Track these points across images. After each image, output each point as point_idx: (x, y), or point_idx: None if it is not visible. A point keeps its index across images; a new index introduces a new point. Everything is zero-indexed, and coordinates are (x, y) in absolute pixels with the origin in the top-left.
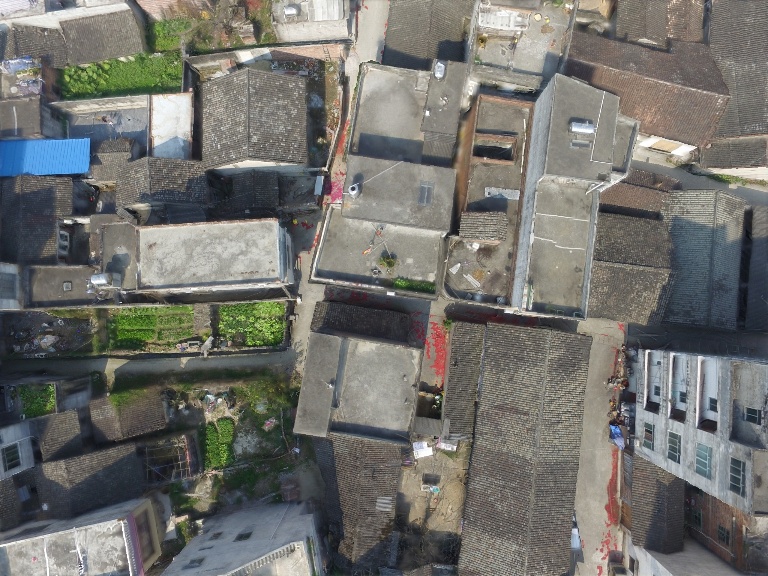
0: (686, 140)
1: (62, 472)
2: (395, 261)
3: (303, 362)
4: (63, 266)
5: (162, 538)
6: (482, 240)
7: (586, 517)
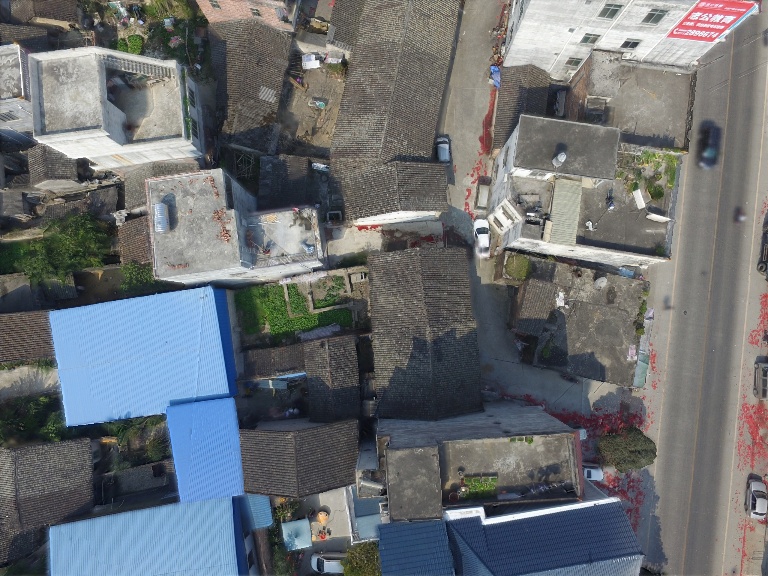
0: None
1: None
2: None
3: None
4: None
5: None
6: None
7: (461, 146)
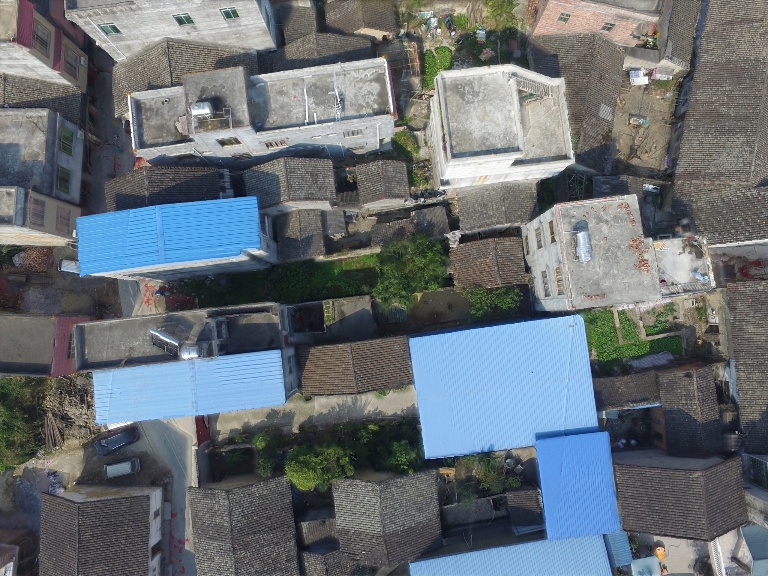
0: None
1: (310, 44)
2: None
3: (518, 5)
4: None
5: (380, 146)
6: None
7: None
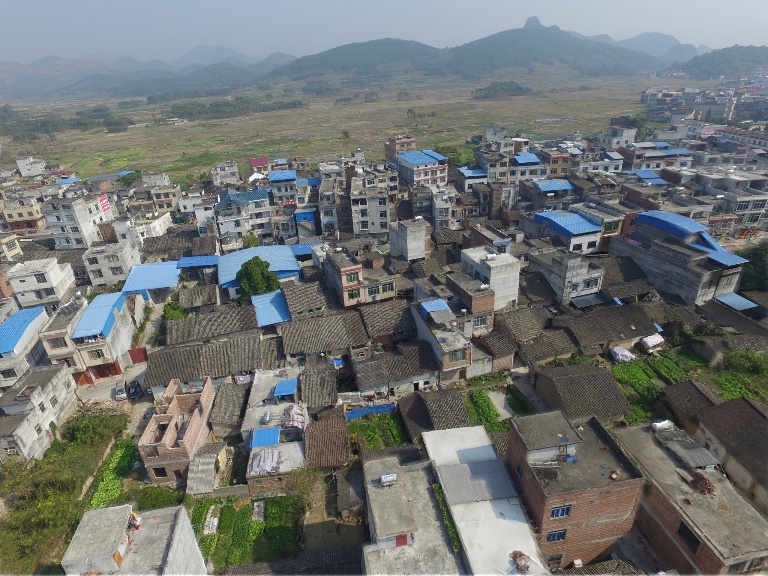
0: None
1: None
2: None
3: None
4: None
5: None
6: None
7: None
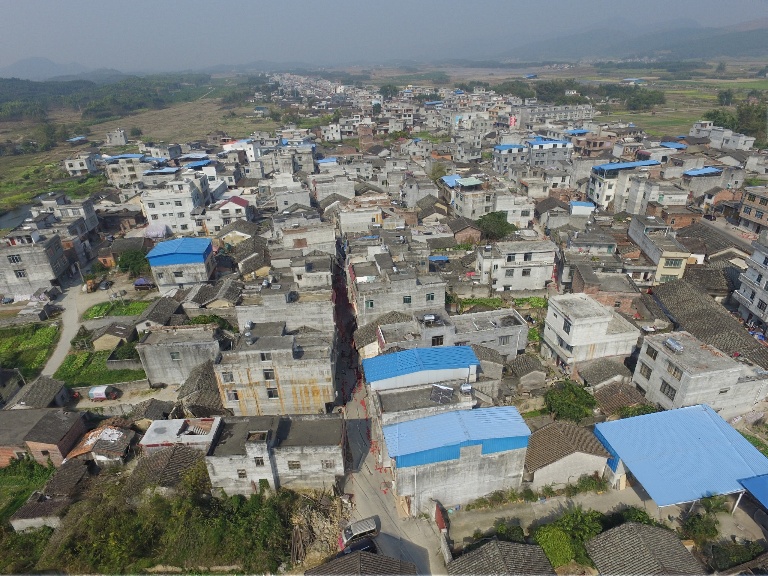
0: (697, 251)
1: None
2: None
3: None
4: (447, 274)
5: None
6: (632, 251)
7: None
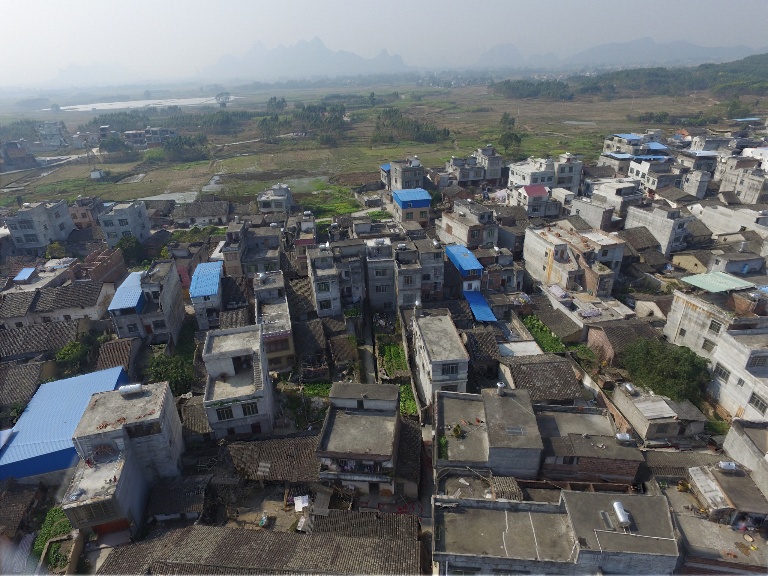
0: None
1: None
2: (460, 438)
3: None
4: None
5: None
6: (493, 485)
7: None
